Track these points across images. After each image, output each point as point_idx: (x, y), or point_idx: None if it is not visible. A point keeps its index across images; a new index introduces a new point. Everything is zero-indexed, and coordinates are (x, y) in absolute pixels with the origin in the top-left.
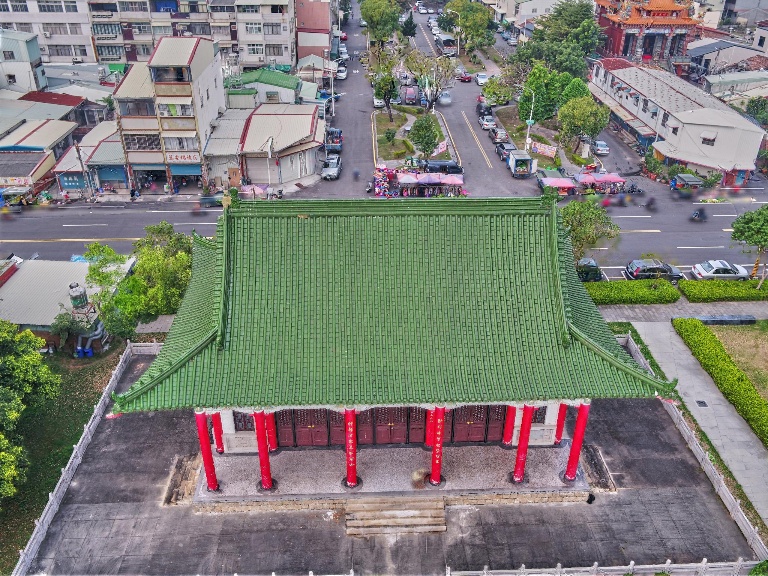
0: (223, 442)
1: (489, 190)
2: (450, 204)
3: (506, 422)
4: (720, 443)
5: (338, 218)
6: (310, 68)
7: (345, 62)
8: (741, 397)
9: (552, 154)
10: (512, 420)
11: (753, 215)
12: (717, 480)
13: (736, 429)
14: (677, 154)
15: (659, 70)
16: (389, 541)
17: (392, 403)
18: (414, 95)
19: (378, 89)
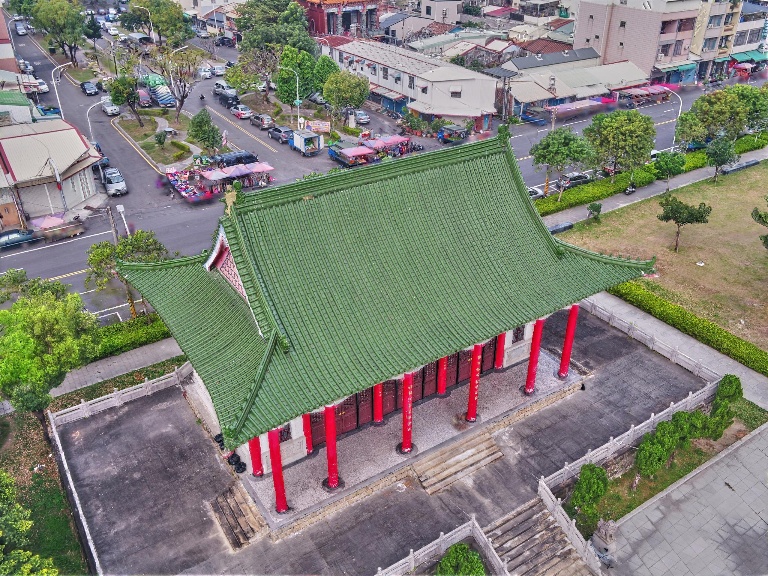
0: (262, 463)
1: (291, 172)
2: (432, 157)
3: (498, 348)
4: None
5: (340, 192)
6: (14, 83)
7: (68, 69)
8: None
9: (327, 129)
10: (503, 344)
11: (549, 141)
12: (650, 339)
13: (617, 305)
14: (434, 110)
15: (375, 42)
16: (468, 483)
17: (466, 347)
18: (148, 97)
19: (115, 94)
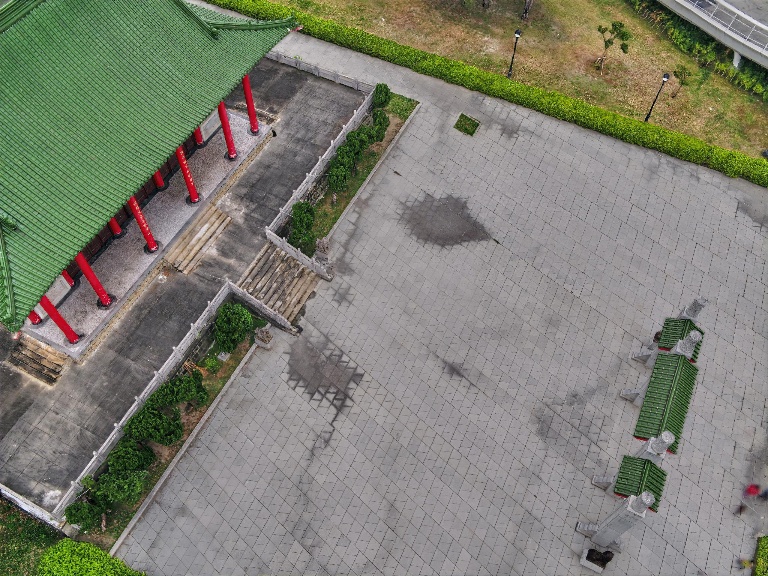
0: (36, 312)
1: None
2: None
3: None
4: (283, 50)
5: None
6: None
7: None
8: (265, 11)
9: None
10: None
11: None
12: (314, 68)
13: None
14: None
15: None
16: (213, 253)
17: None
18: None
19: None
